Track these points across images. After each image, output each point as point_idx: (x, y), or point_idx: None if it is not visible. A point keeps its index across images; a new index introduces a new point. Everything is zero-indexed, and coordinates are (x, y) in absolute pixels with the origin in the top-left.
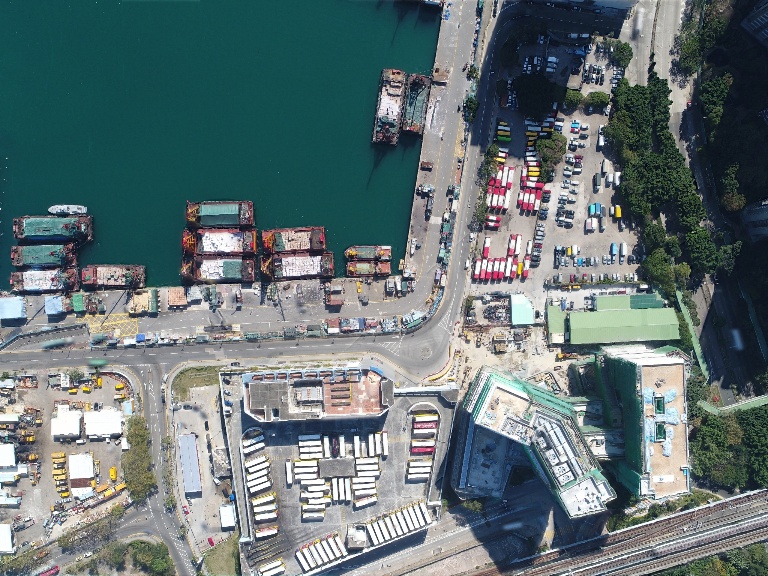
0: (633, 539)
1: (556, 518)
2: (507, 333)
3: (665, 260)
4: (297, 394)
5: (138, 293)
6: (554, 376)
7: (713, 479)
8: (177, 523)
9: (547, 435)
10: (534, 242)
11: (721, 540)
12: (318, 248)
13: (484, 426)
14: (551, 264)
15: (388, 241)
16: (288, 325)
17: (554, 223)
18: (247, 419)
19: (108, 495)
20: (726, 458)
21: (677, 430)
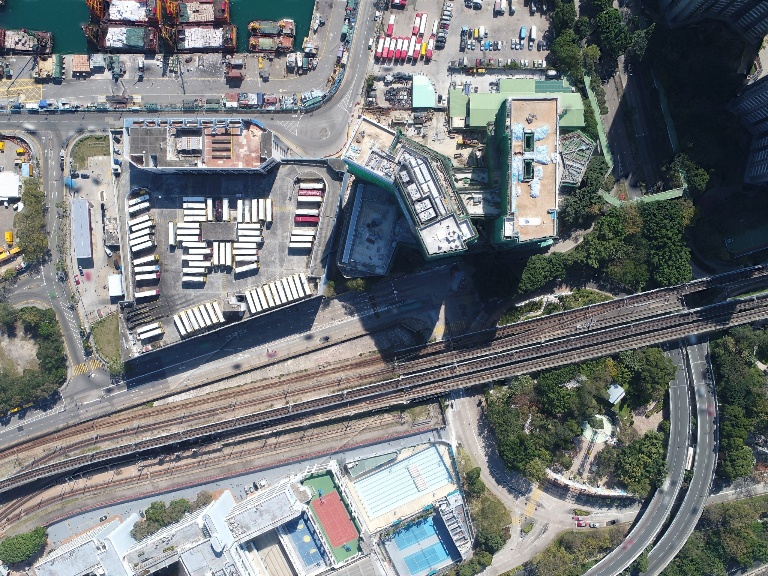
0: (523, 334)
1: (447, 313)
2: (407, 116)
3: (573, 40)
4: (177, 142)
5: (44, 59)
6: (453, 163)
7: (611, 275)
8: (68, 293)
9: (409, 167)
10: (440, 22)
11: (615, 340)
12: (220, 17)
13: (349, 161)
14: (457, 47)
15: (293, 18)
16: (188, 98)
17: (462, 4)
18: (135, 180)
19: (2, 258)
20: (625, 252)
21: (547, 170)
